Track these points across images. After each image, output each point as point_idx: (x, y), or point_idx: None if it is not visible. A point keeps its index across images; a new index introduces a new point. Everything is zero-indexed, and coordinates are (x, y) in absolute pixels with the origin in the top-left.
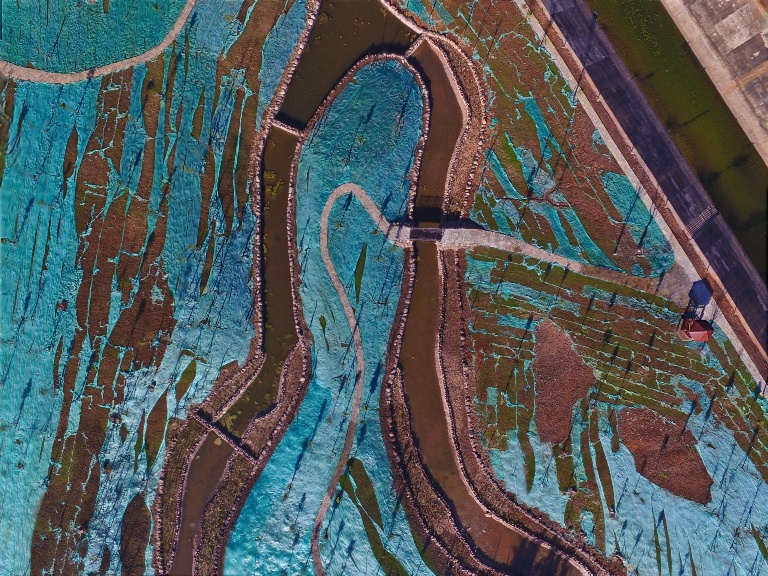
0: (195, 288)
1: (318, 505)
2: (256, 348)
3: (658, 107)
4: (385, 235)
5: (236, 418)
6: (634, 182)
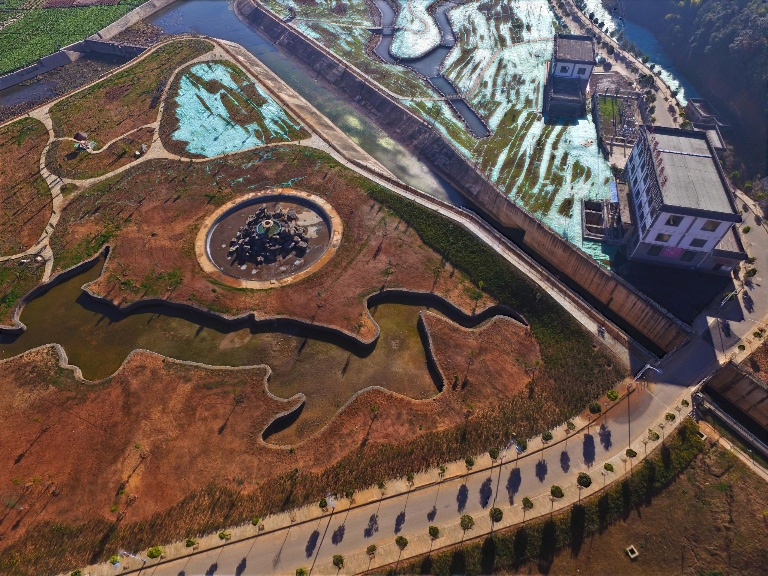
0: (472, 14)
1: None
2: None
3: None
4: None
5: (452, 5)
6: None
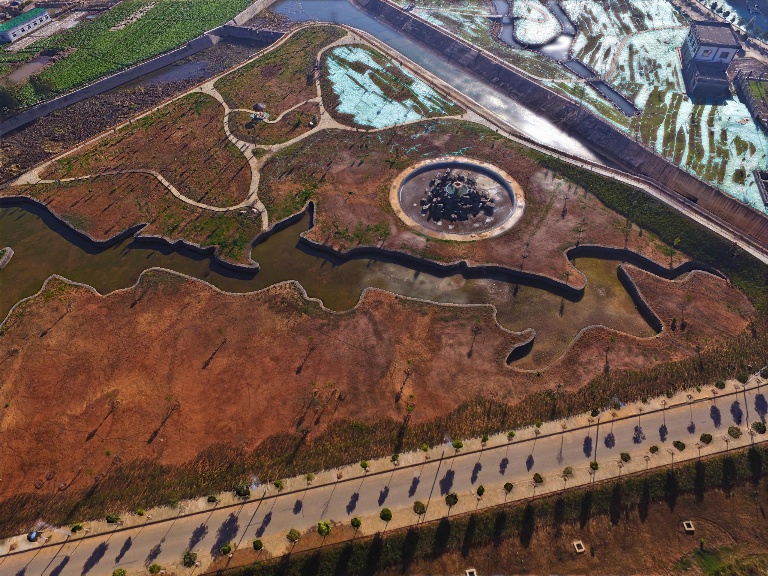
0: (588, 4)
1: None
2: (560, 3)
3: None
4: None
5: None
6: None
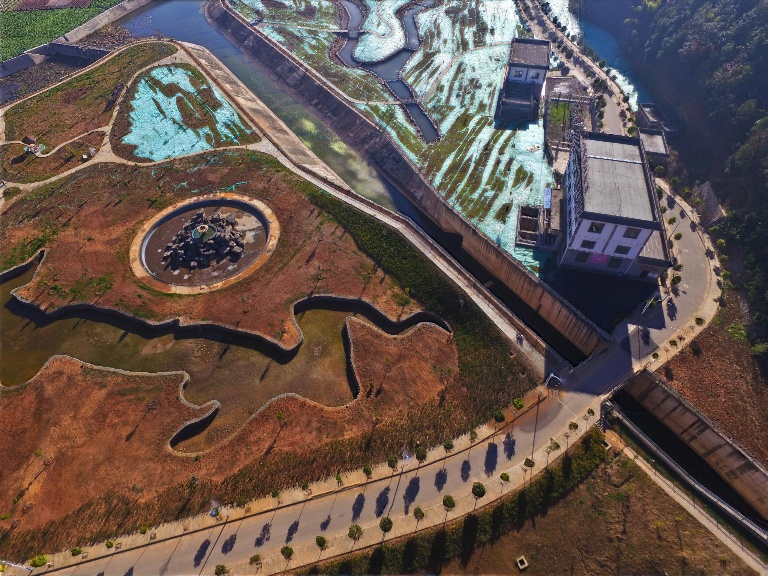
0: None
1: None
2: None
3: (255, 66)
4: None
5: None
6: None
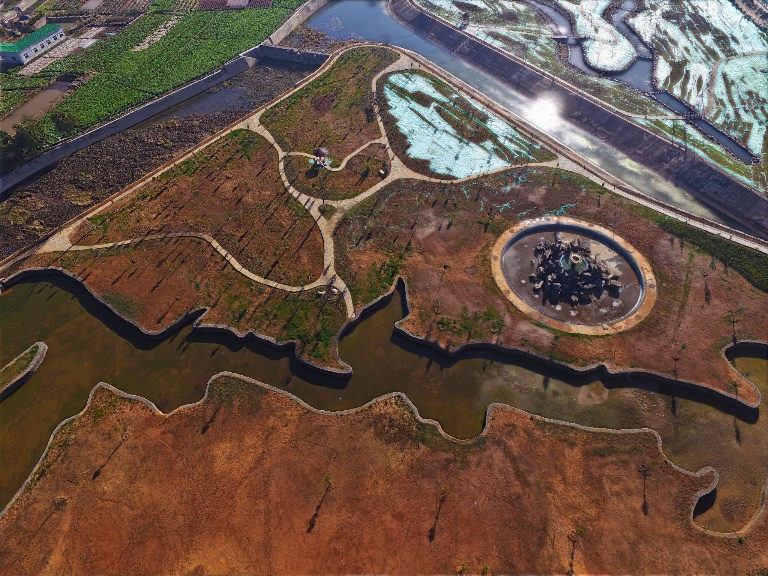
0: (660, 23)
1: None
2: None
3: None
4: None
5: None
6: (494, 45)
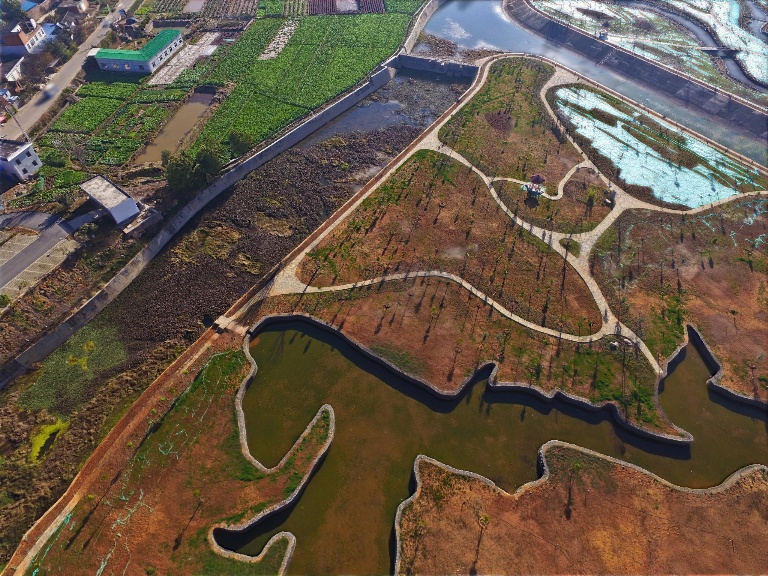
0: None
1: (714, 7)
2: (767, 32)
3: (638, 87)
4: (741, 48)
5: None
6: (647, 57)
